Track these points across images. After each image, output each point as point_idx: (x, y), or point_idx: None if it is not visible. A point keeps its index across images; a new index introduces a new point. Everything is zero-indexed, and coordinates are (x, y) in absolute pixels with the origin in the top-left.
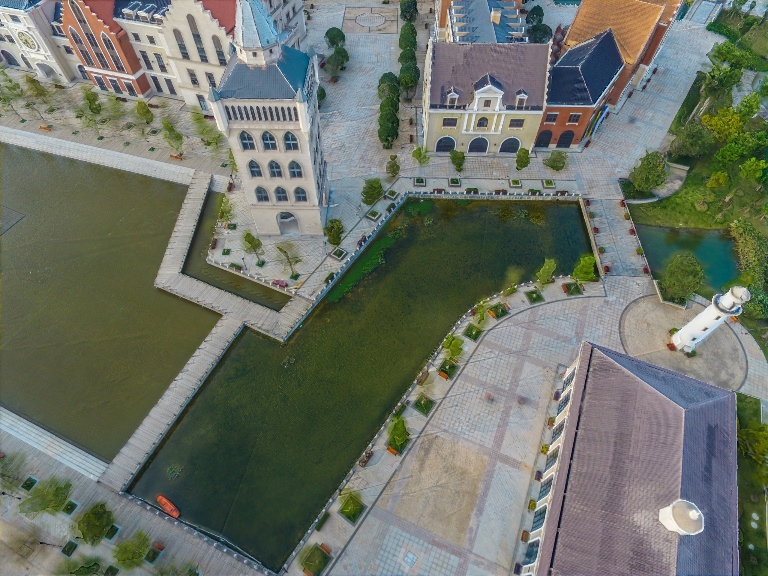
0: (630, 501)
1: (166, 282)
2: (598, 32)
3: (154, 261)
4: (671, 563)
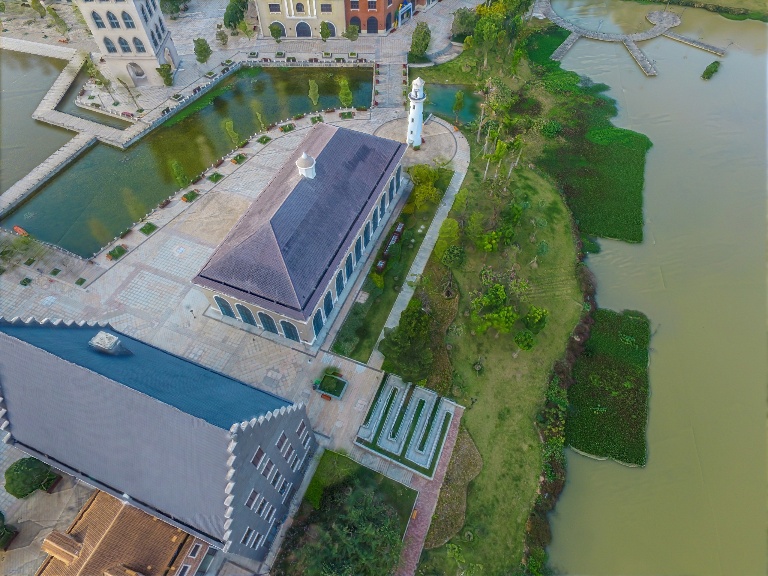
0: (292, 174)
1: (41, 115)
2: None
3: (36, 105)
4: (293, 187)
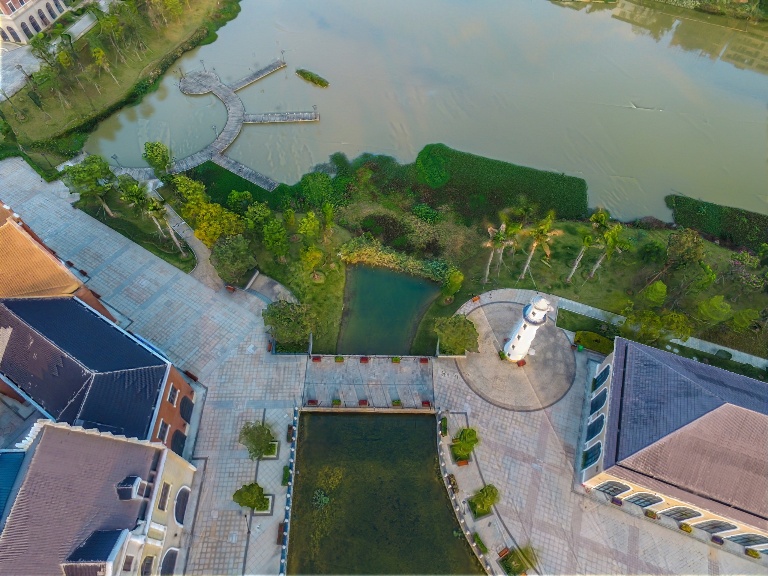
0: None
1: None
2: None
3: None
4: None
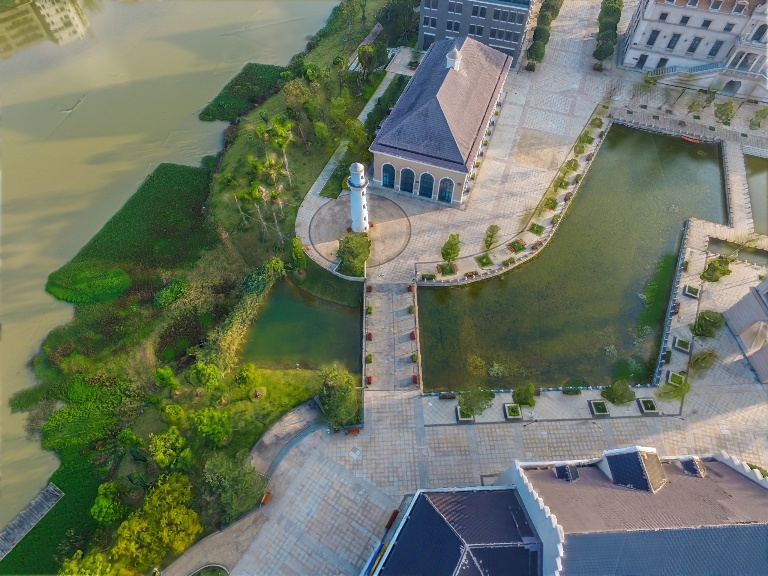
0: None
1: None
2: None
3: None
4: None
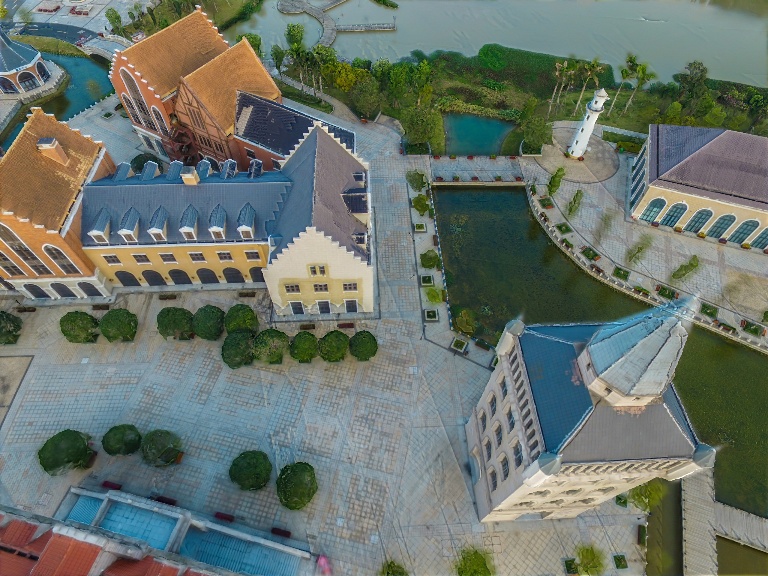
0: None
1: None
2: (234, 102)
3: None
4: None
